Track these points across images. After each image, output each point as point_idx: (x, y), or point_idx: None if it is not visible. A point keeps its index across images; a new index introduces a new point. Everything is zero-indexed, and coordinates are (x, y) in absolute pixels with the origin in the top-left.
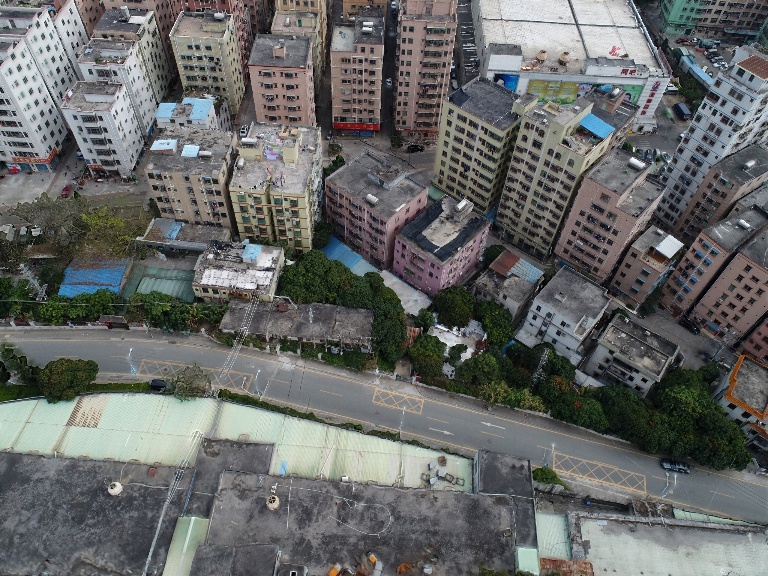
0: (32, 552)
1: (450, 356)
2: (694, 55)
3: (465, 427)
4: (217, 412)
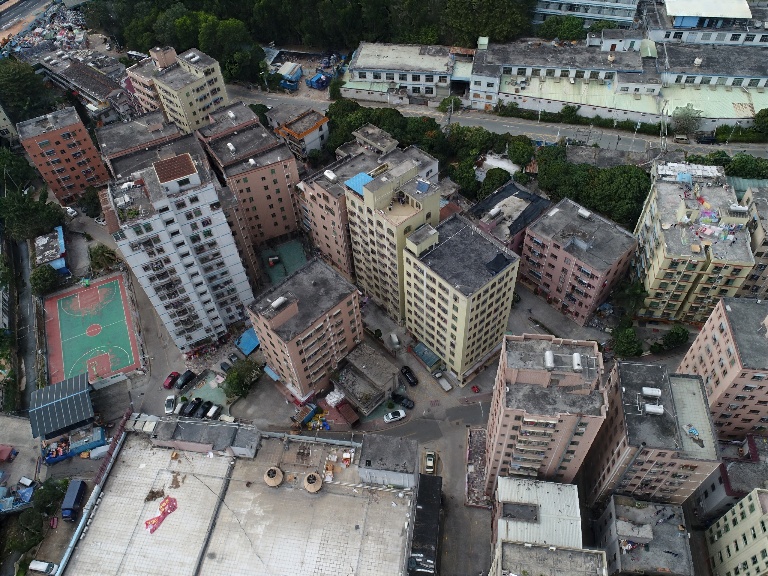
0: None
1: None
2: None
3: (495, 128)
4: (660, 109)
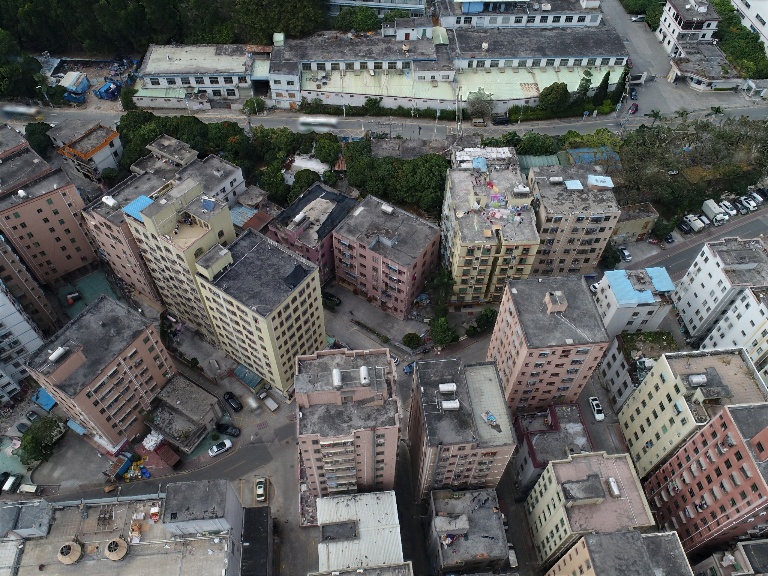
0: None
1: None
2: None
3: (302, 127)
4: None
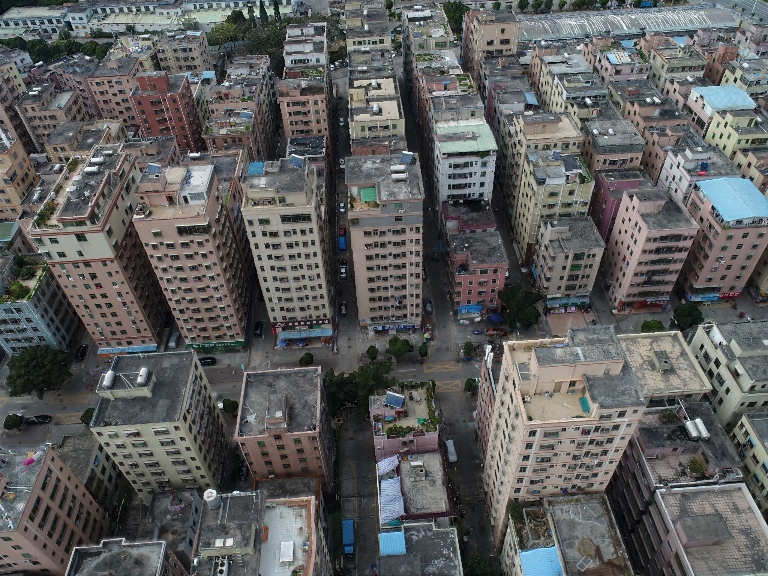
0: None
1: (81, 46)
2: None
3: None
4: None
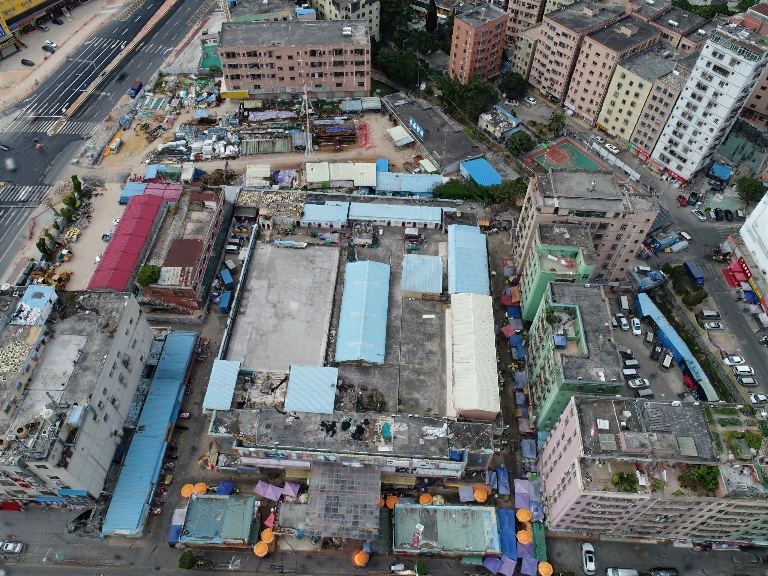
0: None
1: None
2: (686, 395)
3: None
4: None
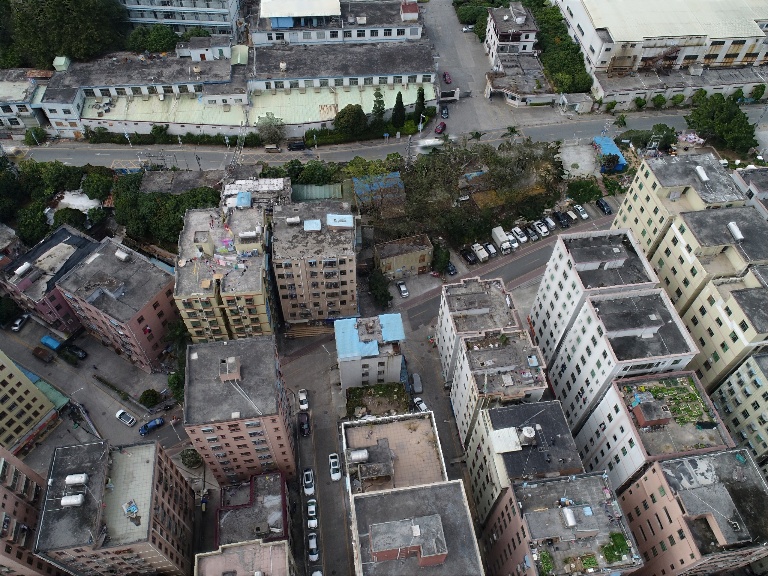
0: (315, 51)
1: None
2: None
3: (84, 159)
4: (248, 120)
